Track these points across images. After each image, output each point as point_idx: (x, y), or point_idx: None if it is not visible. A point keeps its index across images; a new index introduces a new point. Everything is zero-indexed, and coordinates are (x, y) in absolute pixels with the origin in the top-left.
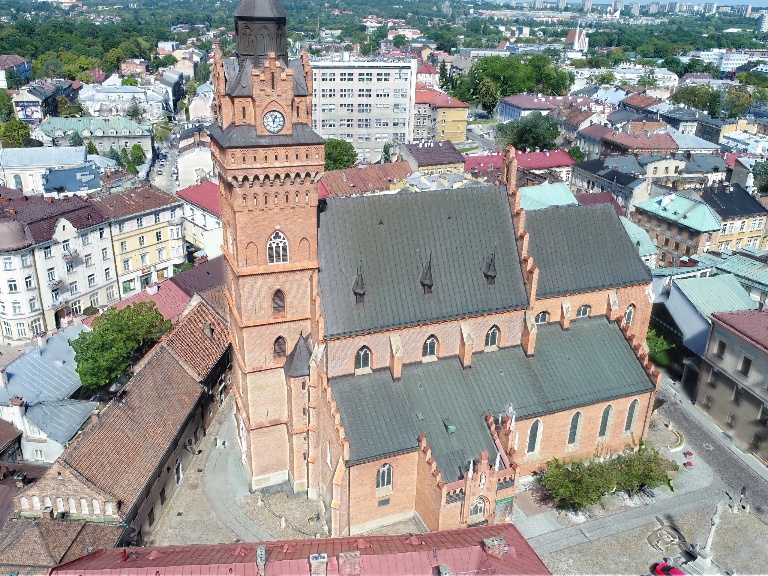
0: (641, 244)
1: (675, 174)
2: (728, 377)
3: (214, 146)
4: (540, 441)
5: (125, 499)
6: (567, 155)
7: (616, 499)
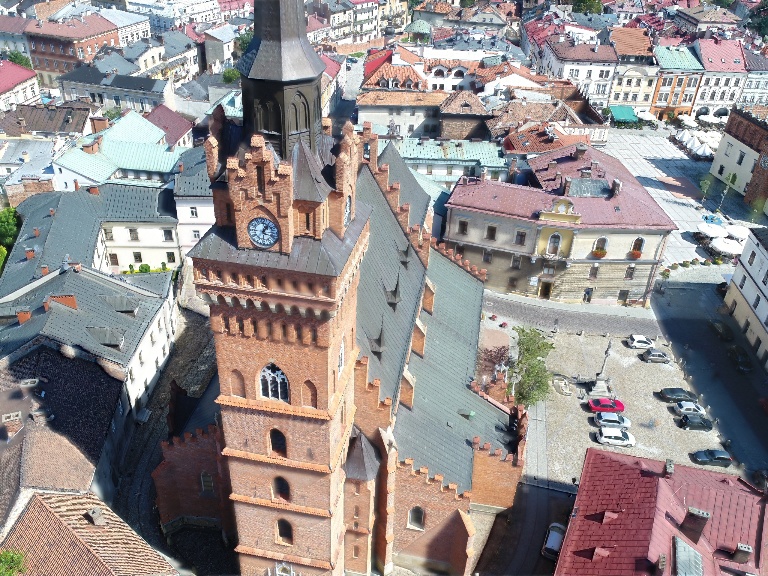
0: None
1: (160, 62)
2: (476, 246)
3: (227, 278)
4: None
5: None
6: (17, 65)
7: None
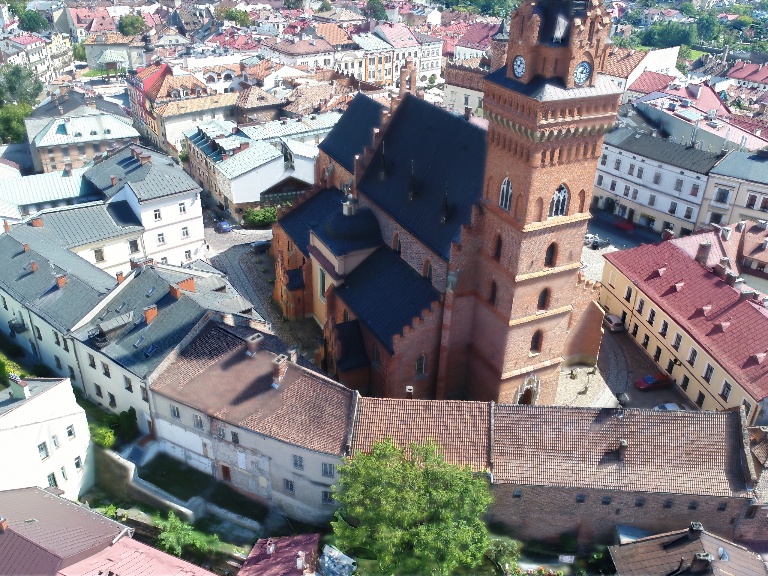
0: None
1: None
2: None
3: None
4: None
5: None
6: None
7: None
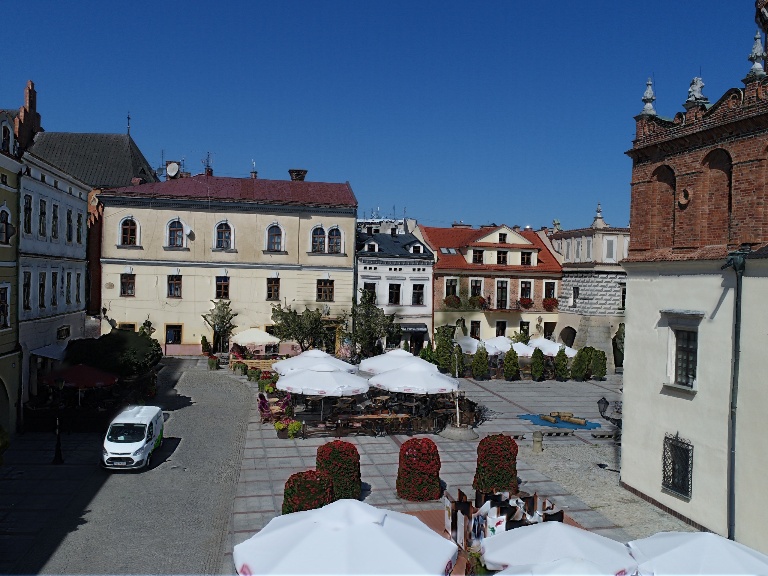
0: None
1: None
2: None
3: None
4: None
5: None
6: None
7: None
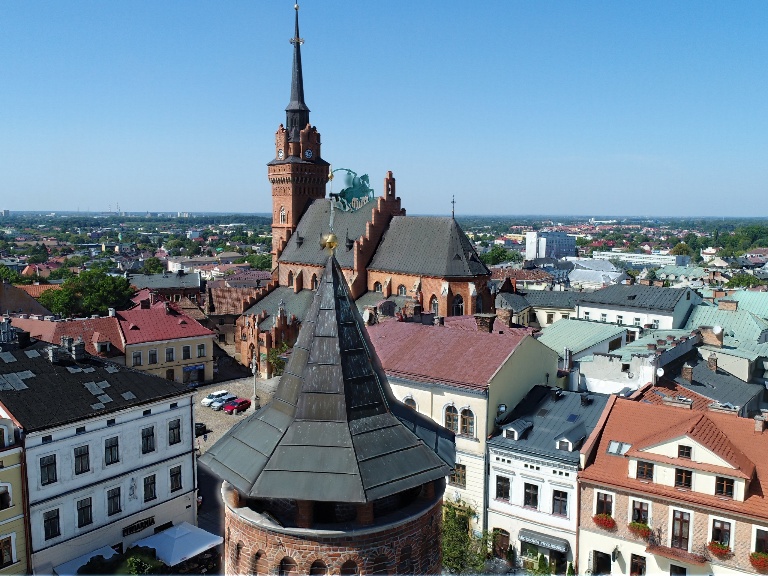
0: None
1: None
2: None
3: None
4: None
5: (218, 312)
6: None
7: None
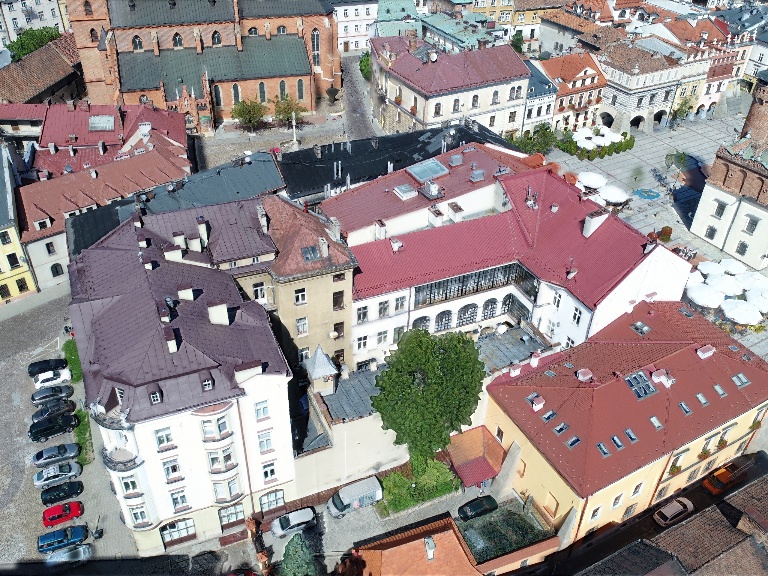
0: (407, 11)
1: None
2: None
3: None
4: (241, 97)
5: None
6: None
7: (280, 130)
